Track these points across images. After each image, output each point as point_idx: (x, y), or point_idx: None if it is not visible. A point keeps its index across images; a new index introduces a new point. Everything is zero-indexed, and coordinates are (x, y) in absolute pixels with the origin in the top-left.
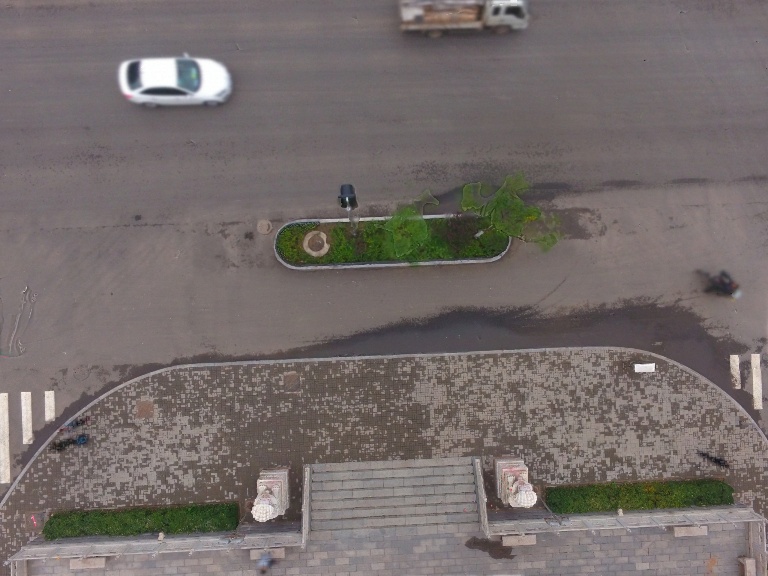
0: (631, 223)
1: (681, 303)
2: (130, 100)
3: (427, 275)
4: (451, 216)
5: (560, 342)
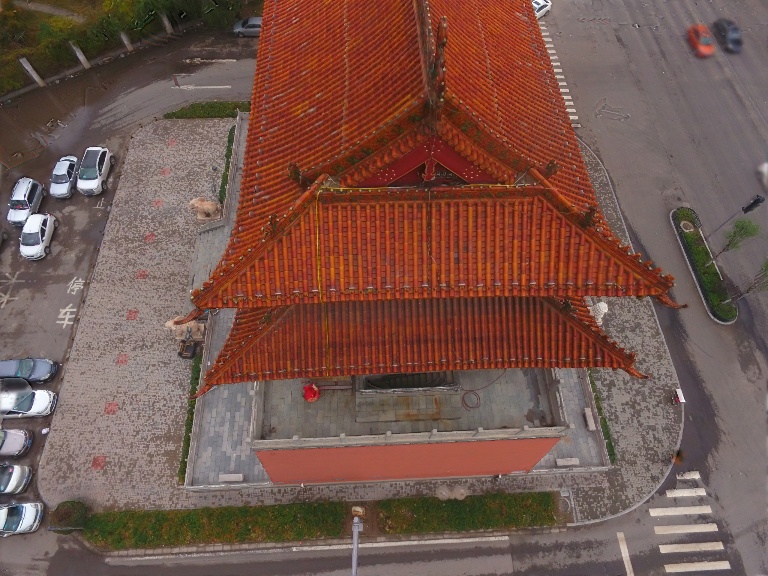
0: (763, 400)
1: (723, 434)
2: (726, 154)
3: (688, 280)
4: None
5: (673, 353)
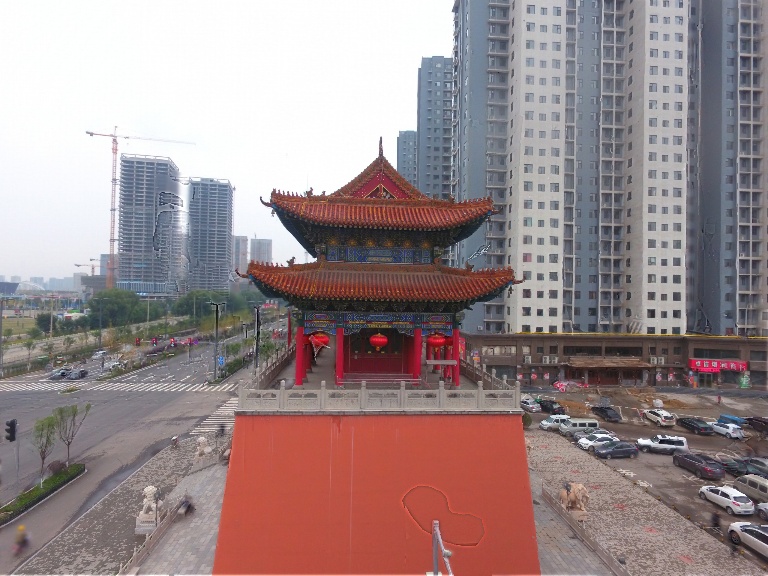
0: (109, 448)
1: None
2: None
3: (71, 487)
4: (48, 468)
5: None
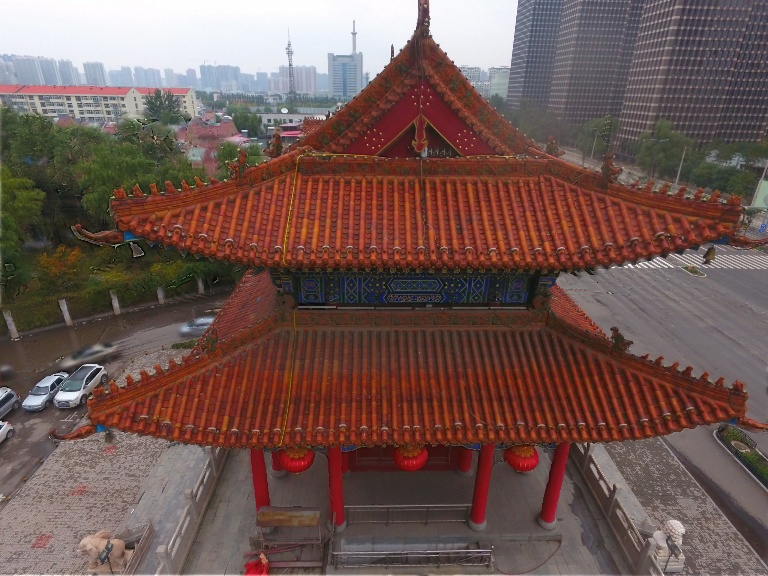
0: None
1: None
2: (745, 381)
3: None
4: None
5: None
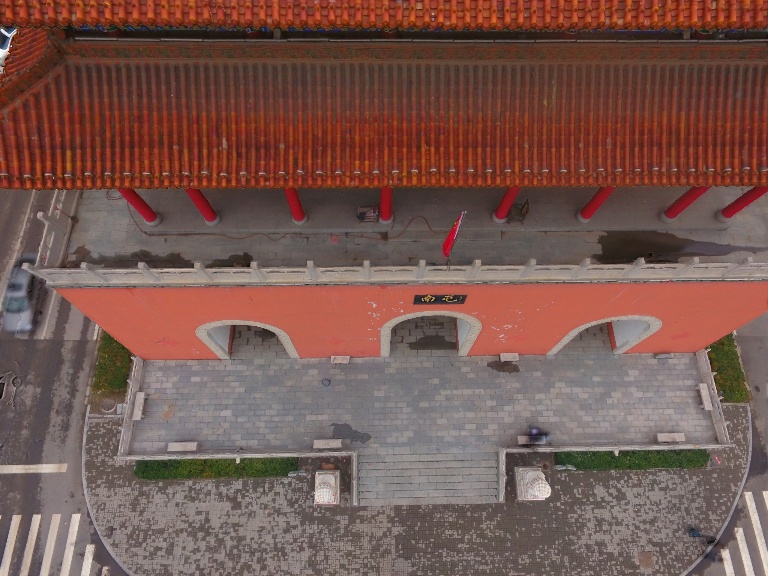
0: None
1: None
2: None
3: None
4: None
5: None
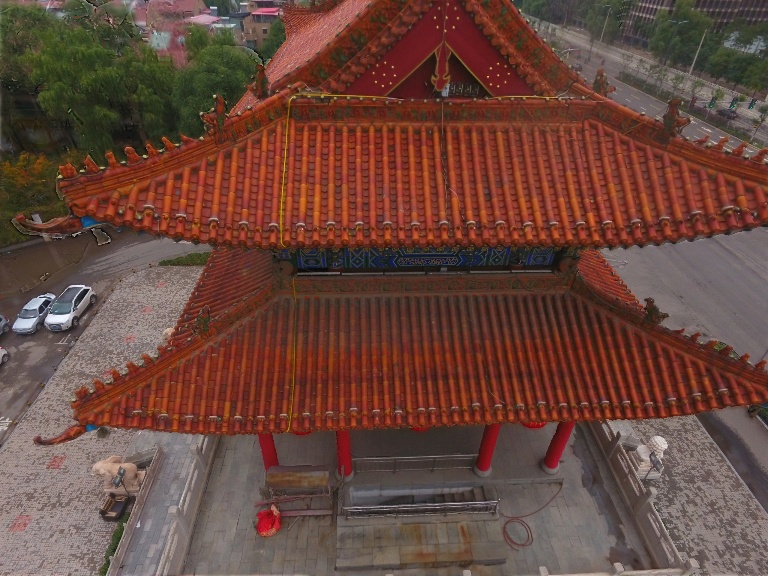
0: None
1: None
2: (737, 294)
3: None
4: None
5: None
